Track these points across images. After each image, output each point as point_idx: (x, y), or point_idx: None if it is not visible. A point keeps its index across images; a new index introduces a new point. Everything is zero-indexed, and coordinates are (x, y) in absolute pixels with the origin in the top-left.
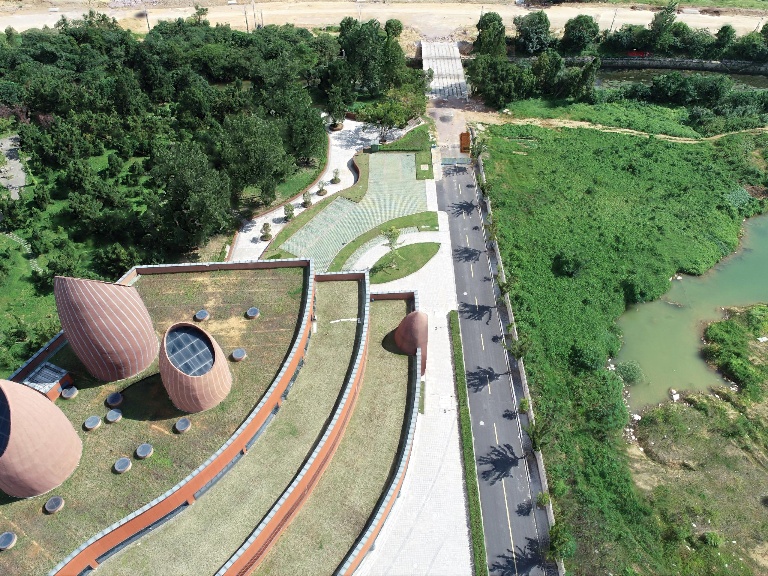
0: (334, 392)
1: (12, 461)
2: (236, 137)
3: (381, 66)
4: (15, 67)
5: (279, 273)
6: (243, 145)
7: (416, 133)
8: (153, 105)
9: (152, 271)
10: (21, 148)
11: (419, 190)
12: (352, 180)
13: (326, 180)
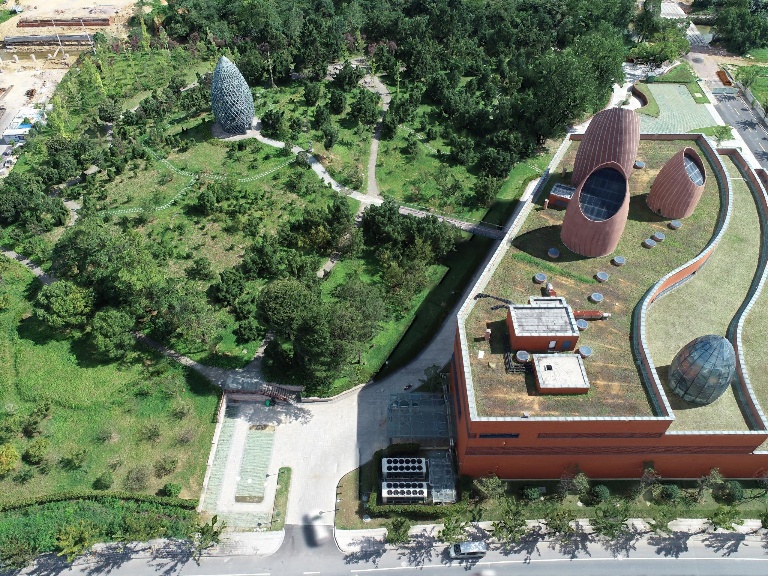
0: (755, 219)
1: (617, 220)
2: (591, 52)
3: (639, 15)
4: (320, 9)
5: (677, 143)
6: (597, 59)
7: (679, 70)
8: (466, 38)
9: (580, 138)
10: None
11: (703, 111)
12: (639, 103)
13: (617, 102)
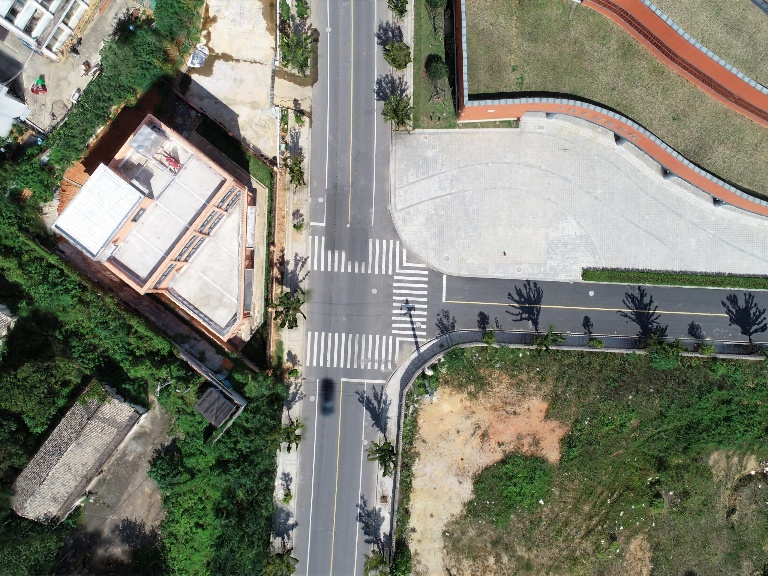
0: None
1: None
2: None
3: None
4: None
5: None
6: None
7: None
8: None
9: None
10: None
11: None
12: None
13: None
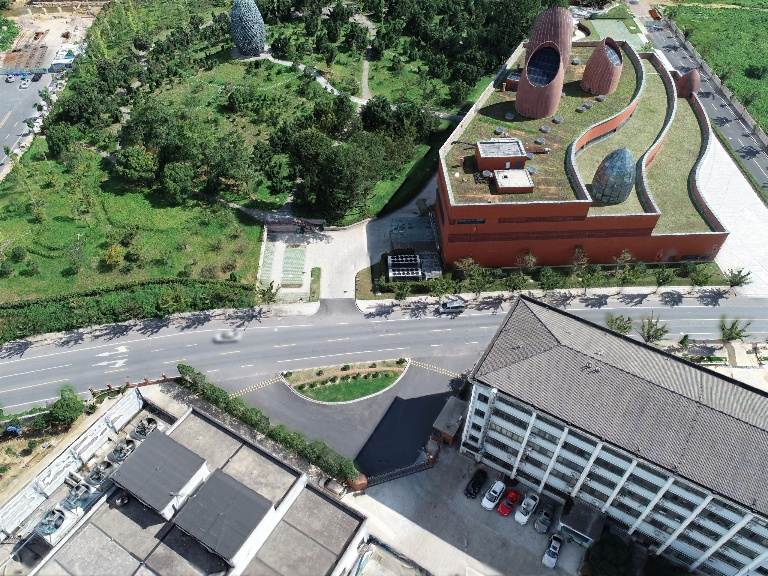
0: (664, 99)
1: (555, 85)
2: None
3: None
4: None
5: None
6: None
7: (618, 9)
8: None
9: None
10: (359, 8)
11: (636, 39)
12: (584, 35)
13: None
